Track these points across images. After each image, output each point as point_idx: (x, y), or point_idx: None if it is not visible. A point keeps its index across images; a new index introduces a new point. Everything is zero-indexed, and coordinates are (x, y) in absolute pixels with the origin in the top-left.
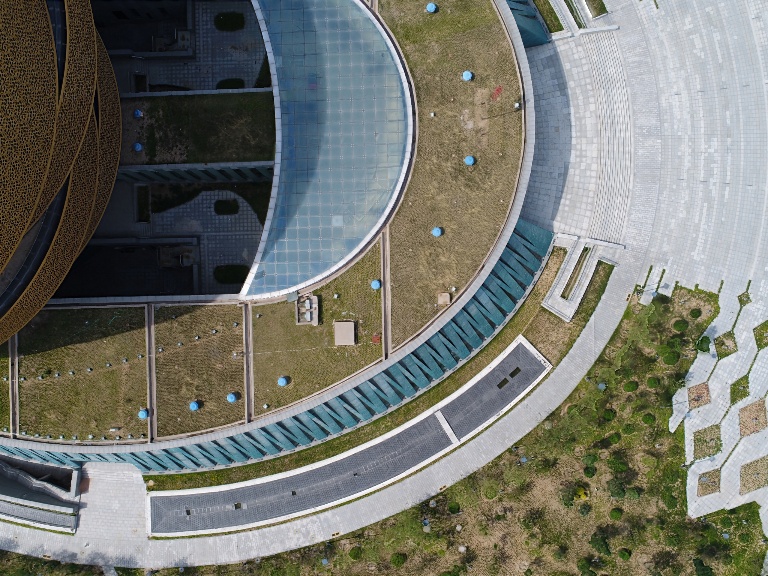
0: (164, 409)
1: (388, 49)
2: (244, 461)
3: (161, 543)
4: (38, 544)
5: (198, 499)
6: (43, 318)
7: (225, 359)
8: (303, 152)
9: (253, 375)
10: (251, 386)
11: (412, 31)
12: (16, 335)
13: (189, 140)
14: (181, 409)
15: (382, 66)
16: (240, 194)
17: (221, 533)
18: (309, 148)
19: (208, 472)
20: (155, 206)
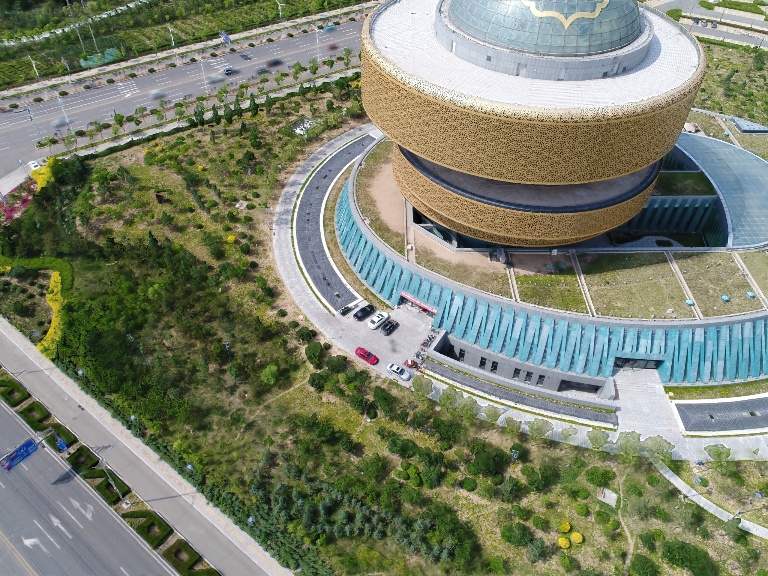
0: (701, 303)
1: (759, 159)
2: (744, 379)
3: (697, 440)
4: (585, 437)
5: (716, 407)
6: (594, 257)
7: (732, 278)
8: (733, 191)
9: (757, 285)
10: (759, 292)
11: (766, 155)
12: (578, 264)
13: (660, 188)
14: (714, 303)
15: (759, 164)
16: (670, 238)
17: (747, 434)
18: (736, 190)
19: (716, 388)
20: (617, 241)
